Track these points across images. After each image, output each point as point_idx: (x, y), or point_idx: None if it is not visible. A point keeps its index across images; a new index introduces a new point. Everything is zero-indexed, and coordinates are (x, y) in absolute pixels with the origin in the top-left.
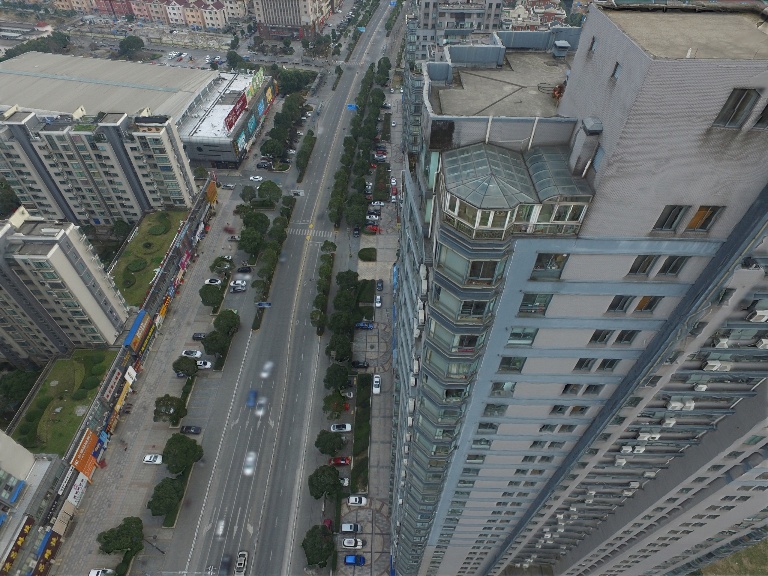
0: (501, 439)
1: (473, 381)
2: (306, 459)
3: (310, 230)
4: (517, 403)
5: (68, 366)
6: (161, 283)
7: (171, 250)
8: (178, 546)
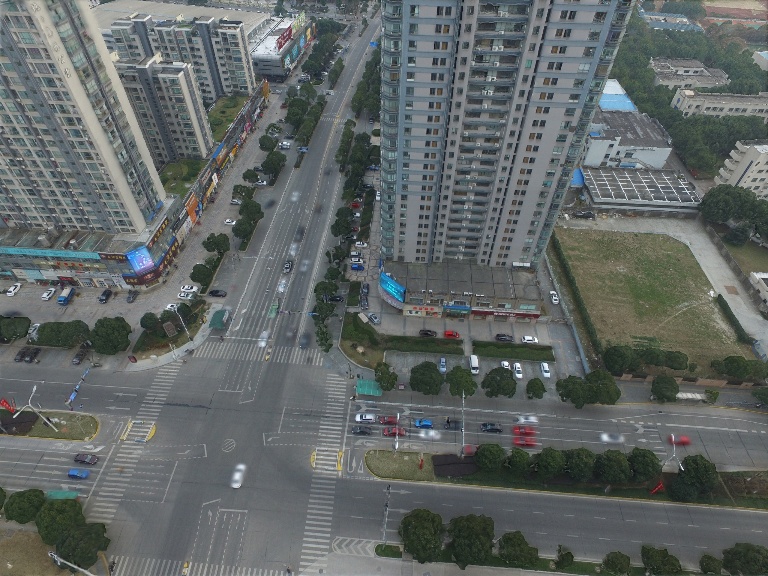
0: (419, 56)
1: (402, 4)
2: (329, 228)
3: (337, 119)
4: (421, 22)
5: (177, 166)
6: (233, 134)
7: (239, 115)
8: (248, 259)
